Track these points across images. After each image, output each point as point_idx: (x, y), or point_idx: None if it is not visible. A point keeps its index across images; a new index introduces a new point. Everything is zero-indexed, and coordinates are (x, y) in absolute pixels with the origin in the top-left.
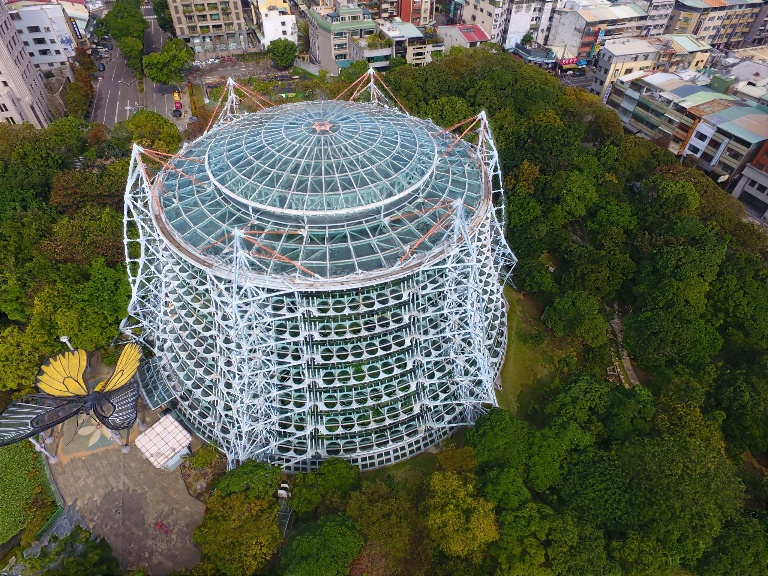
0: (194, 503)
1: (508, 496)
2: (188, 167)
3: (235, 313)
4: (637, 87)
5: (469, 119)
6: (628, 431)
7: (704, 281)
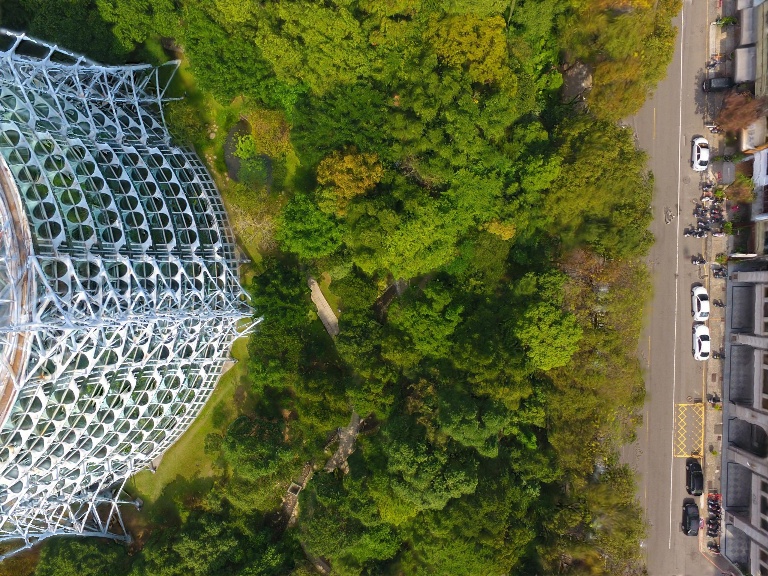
0: None
1: None
2: None
3: None
4: None
5: None
6: None
7: None
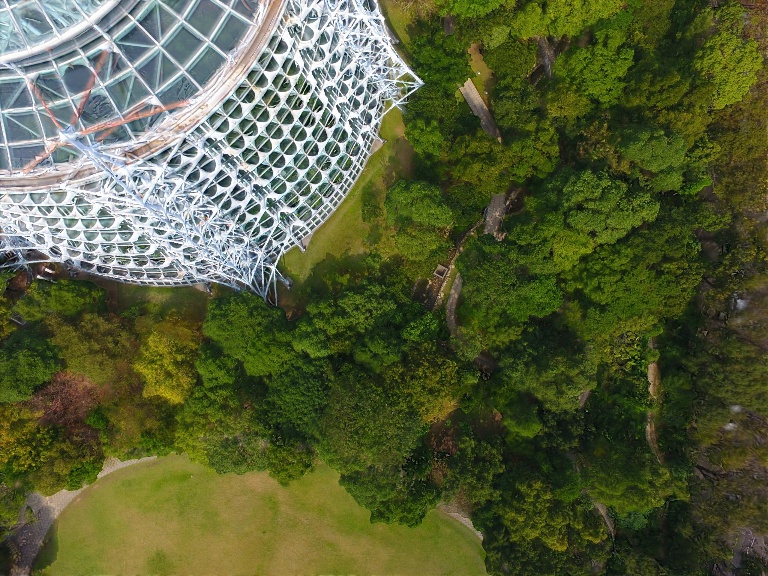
0: None
1: (205, 378)
2: None
3: None
4: None
5: None
6: (365, 361)
7: (594, 241)
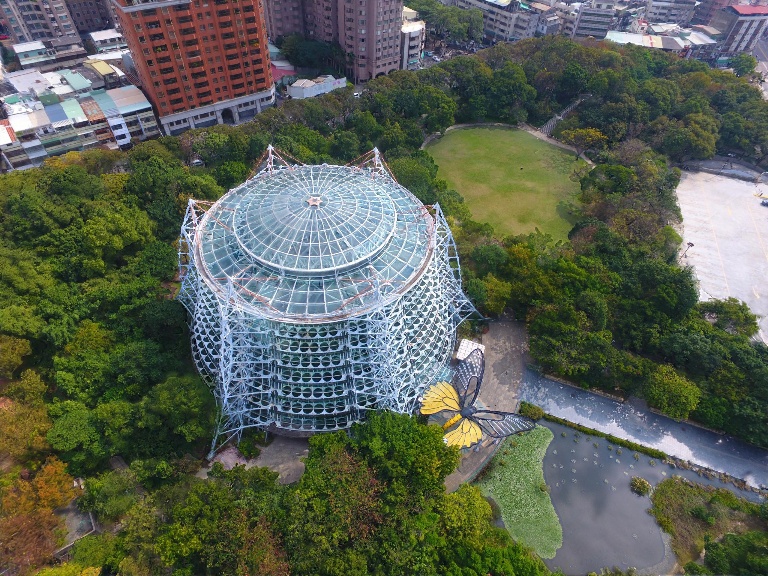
0: (484, 341)
1: None
2: None
3: (450, 237)
4: (20, 139)
5: None
6: None
7: None
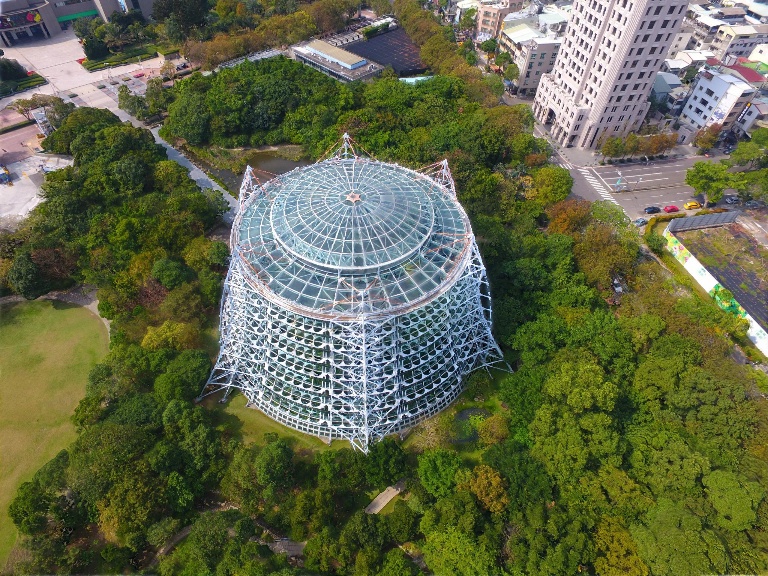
0: None
1: None
2: None
3: None
4: None
5: None
6: None
7: None
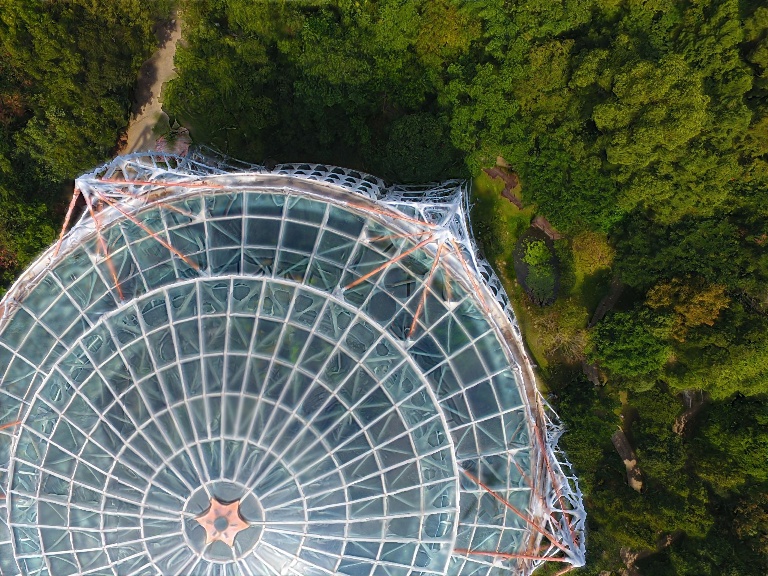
0: None
1: None
2: (7, 394)
3: None
4: None
5: (550, 540)
6: None
7: None
